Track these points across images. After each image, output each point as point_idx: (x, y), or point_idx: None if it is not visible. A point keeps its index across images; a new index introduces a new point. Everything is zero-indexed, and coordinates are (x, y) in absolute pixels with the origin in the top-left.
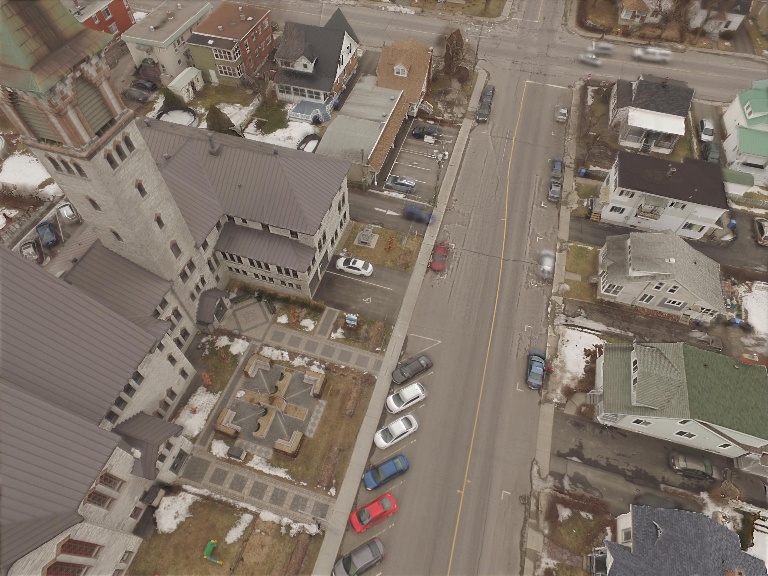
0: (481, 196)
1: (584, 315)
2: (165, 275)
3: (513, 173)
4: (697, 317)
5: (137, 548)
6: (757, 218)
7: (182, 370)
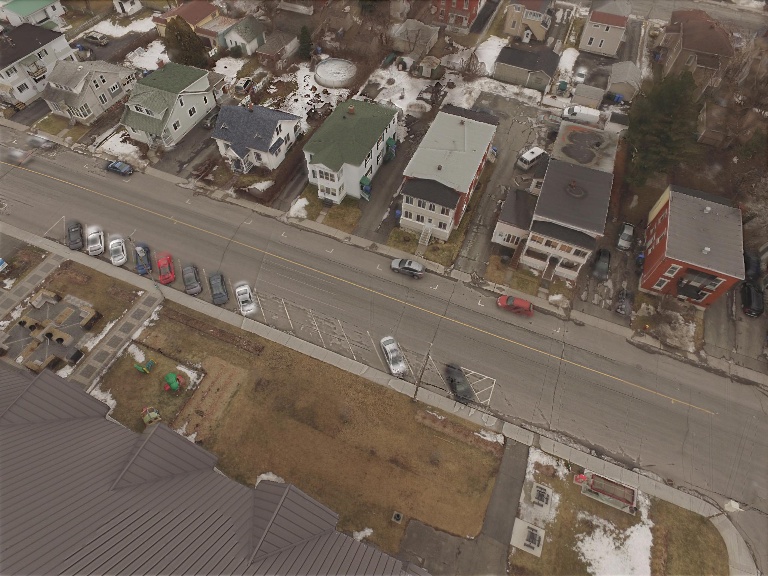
0: None
1: (97, 136)
2: None
3: None
4: (132, 87)
5: None
6: (84, 37)
7: None
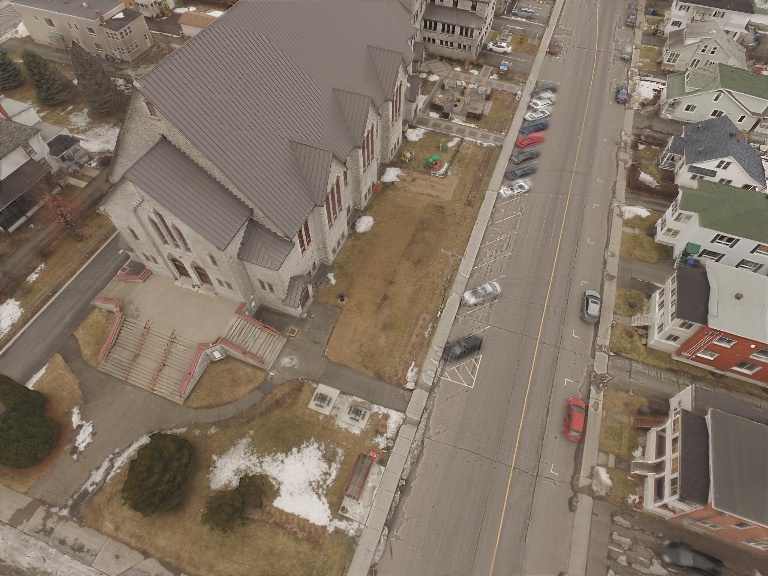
0: (579, 22)
1: (652, 76)
2: (412, 8)
3: (601, 12)
4: None
5: (400, 144)
6: None
7: None
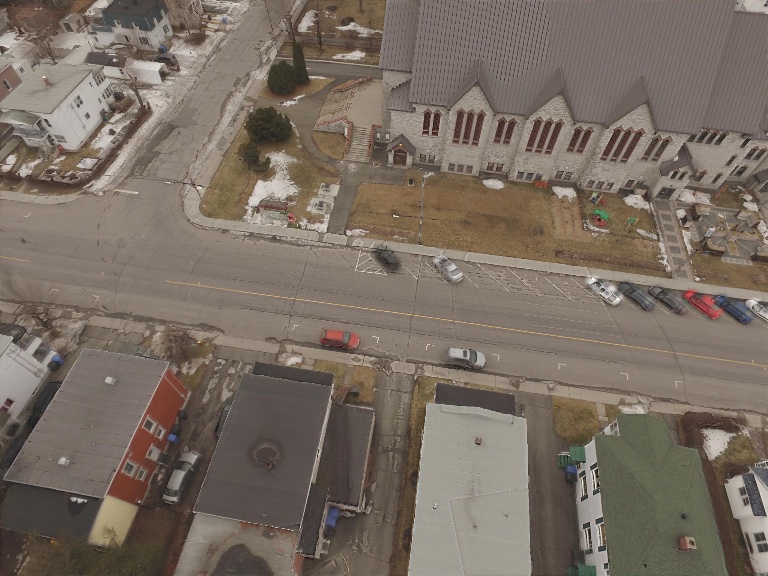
0: None
1: None
2: None
3: None
4: None
5: (612, 192)
6: None
7: (720, 175)
